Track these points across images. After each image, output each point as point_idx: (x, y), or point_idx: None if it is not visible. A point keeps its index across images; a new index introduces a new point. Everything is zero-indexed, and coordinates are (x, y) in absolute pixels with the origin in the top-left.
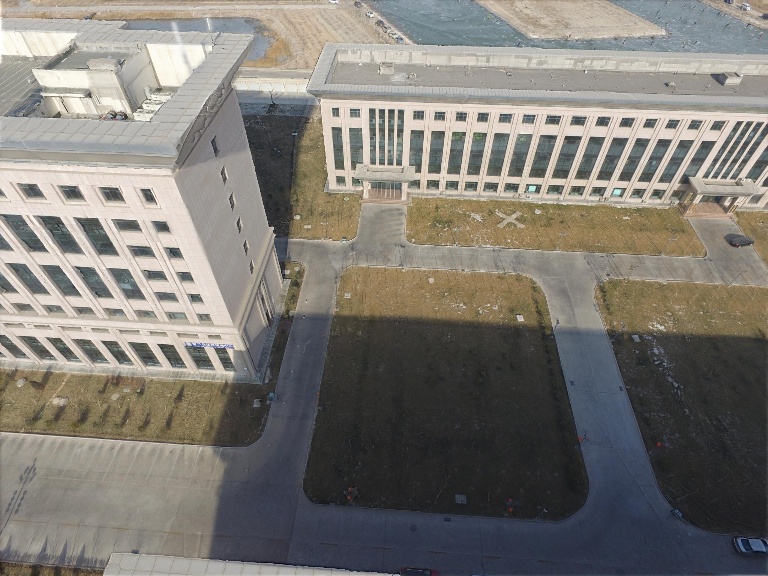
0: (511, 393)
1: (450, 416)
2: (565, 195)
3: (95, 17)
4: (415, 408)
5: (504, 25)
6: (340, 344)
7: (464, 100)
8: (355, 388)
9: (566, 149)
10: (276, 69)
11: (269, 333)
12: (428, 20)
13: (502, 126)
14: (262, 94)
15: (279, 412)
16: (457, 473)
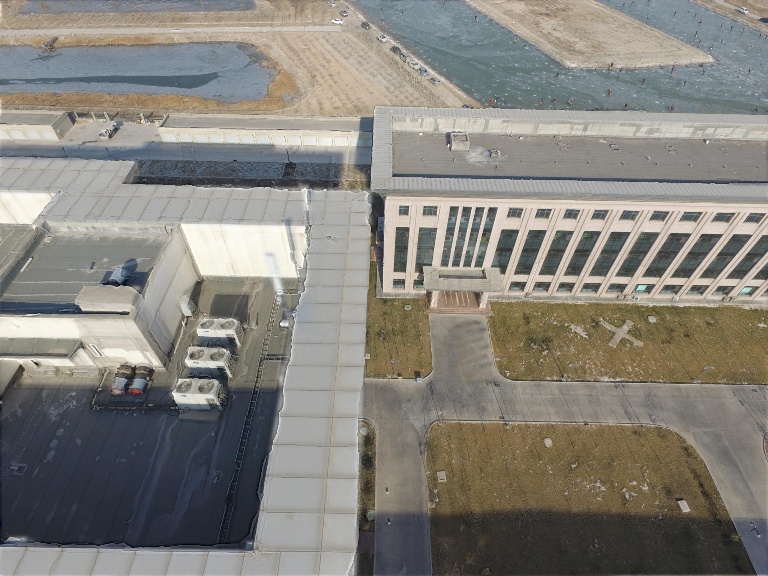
0: None
1: None
2: (681, 295)
3: (57, 43)
4: None
5: (534, 50)
6: None
7: (583, 198)
8: None
9: (697, 247)
10: (289, 117)
11: None
12: (448, 45)
13: (622, 224)
14: (274, 149)
15: None
16: None
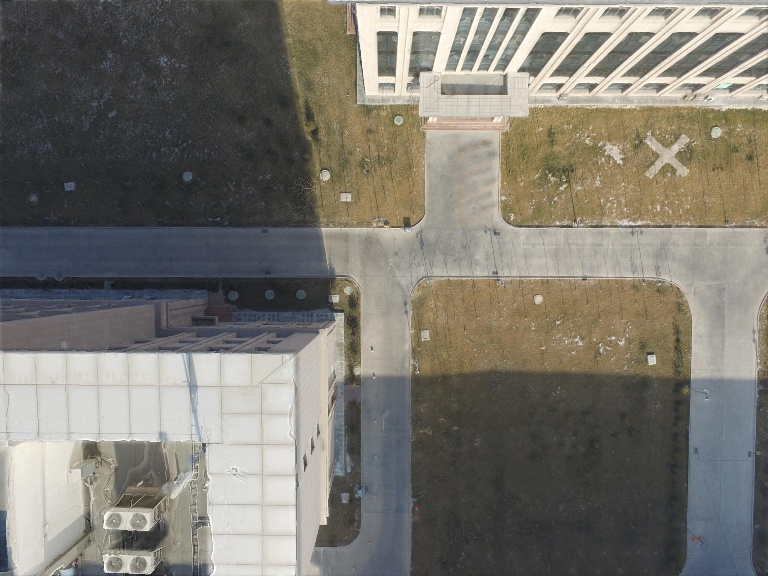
0: (624, 466)
1: (554, 497)
2: None
3: None
4: (517, 491)
5: None
6: (425, 414)
7: None
8: (449, 470)
9: None
10: None
11: (336, 407)
12: None
13: (738, 23)
14: None
15: (371, 506)
16: (559, 557)
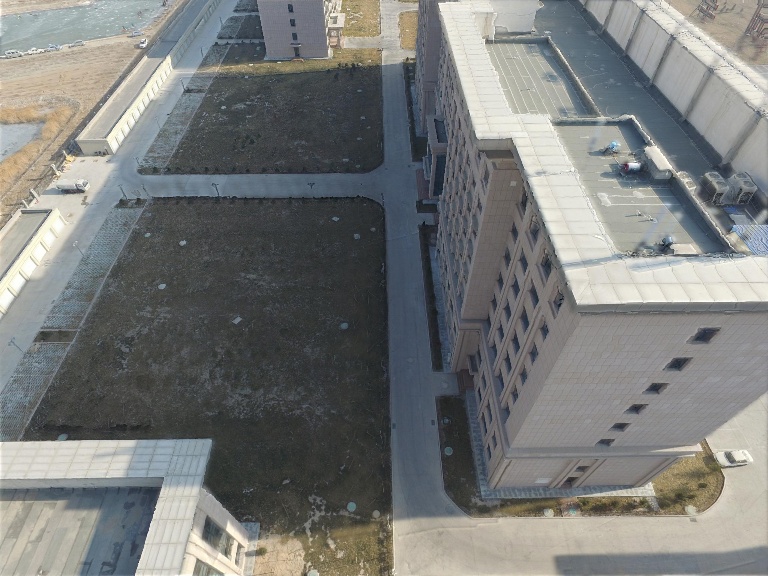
0: None
1: None
2: (337, 0)
3: None
4: None
5: (44, 12)
6: None
7: None
8: None
9: None
10: (124, 82)
11: None
12: None
13: None
14: (158, 100)
15: None
16: None
